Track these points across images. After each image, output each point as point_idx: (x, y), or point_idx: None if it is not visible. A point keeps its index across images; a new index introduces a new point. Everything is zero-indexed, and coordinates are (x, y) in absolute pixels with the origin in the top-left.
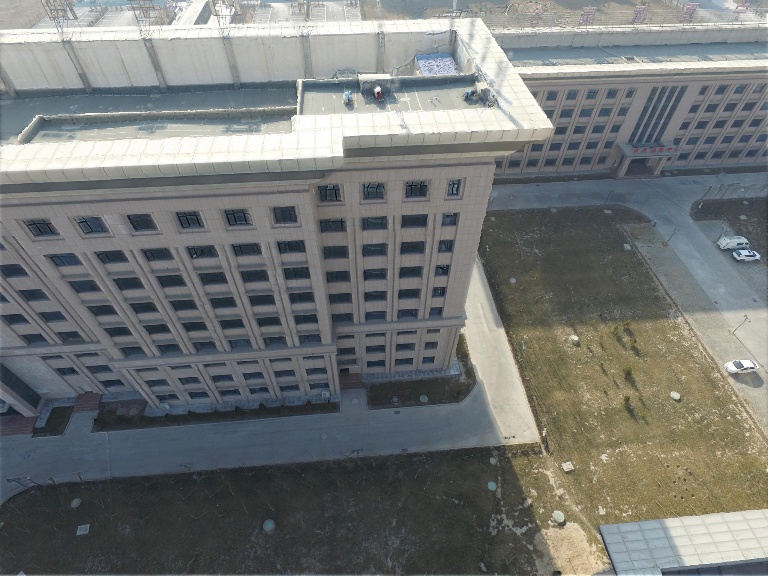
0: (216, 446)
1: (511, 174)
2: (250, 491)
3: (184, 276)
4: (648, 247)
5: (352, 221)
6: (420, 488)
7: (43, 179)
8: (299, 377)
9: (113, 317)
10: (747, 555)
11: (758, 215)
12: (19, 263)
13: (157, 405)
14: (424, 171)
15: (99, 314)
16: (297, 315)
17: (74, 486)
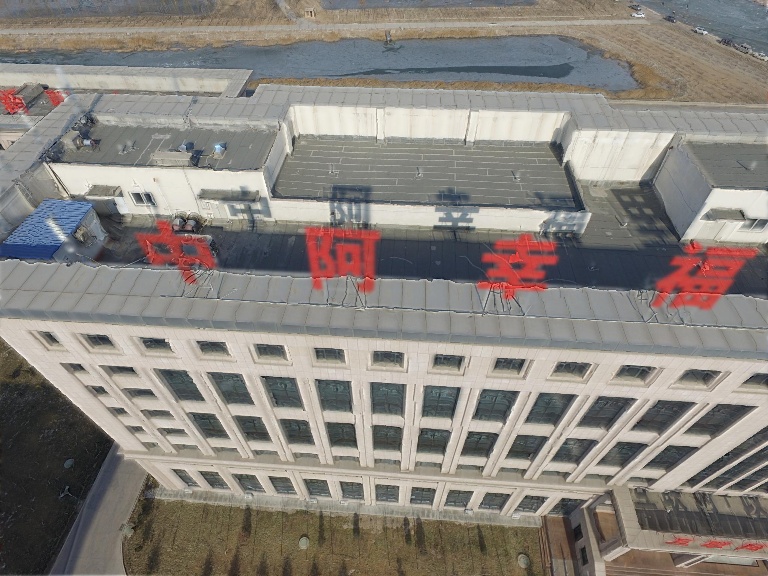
0: None
1: None
2: None
3: None
4: None
5: None
6: None
7: None
8: None
9: None
10: None
11: None
12: None
13: None
14: None
15: None
16: None
17: None
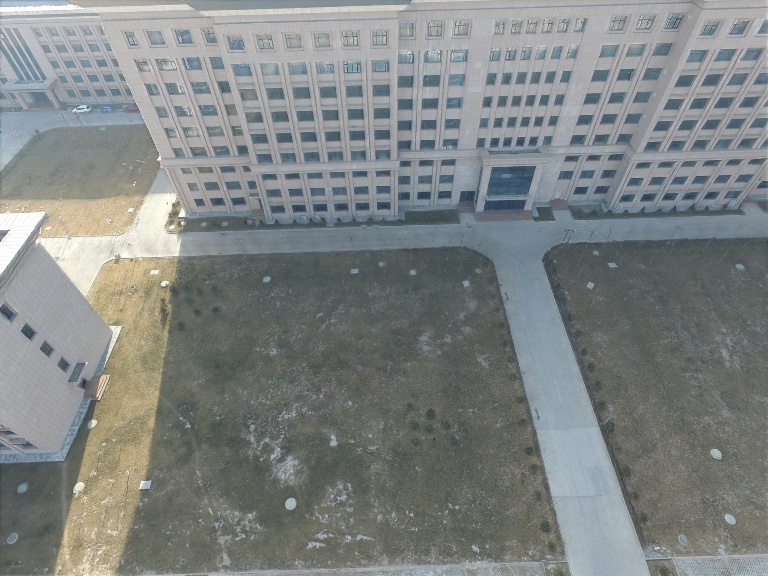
0: (669, 229)
1: None
2: (713, 250)
3: (751, 74)
4: None
5: None
6: None
7: None
8: (728, 184)
9: (671, 111)
10: None
11: None
12: (638, 67)
13: (614, 205)
14: None
15: (664, 109)
16: None
17: (588, 245)
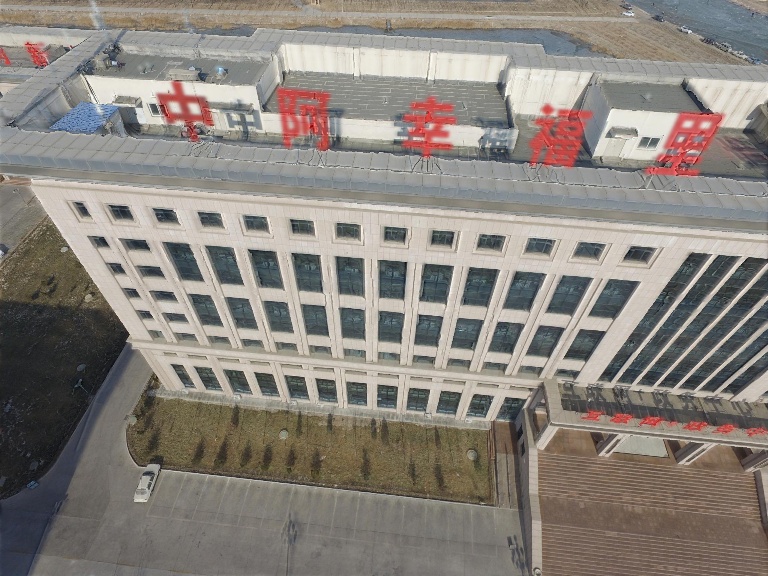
0: None
1: None
2: None
3: None
4: None
5: None
6: None
7: None
8: None
9: None
10: None
11: None
12: None
13: None
14: None
15: None
16: None
17: None
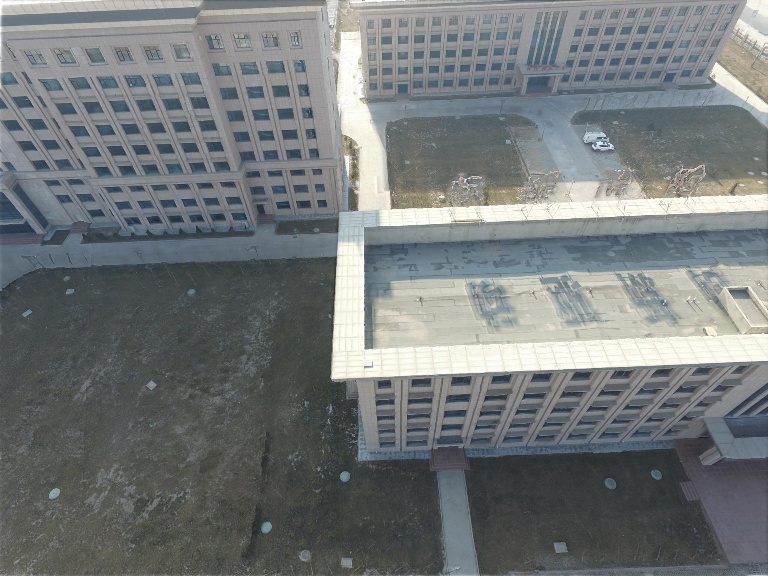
0: (164, 252)
1: (431, 93)
2: (182, 275)
3: (126, 101)
4: (525, 142)
5: (233, 65)
6: (299, 277)
7: (31, 11)
8: (223, 206)
9: (86, 138)
10: (418, 223)
11: (629, 121)
12: (26, 95)
13: (126, 228)
14: (270, 24)
15: (77, 135)
16: (208, 142)
17: (66, 270)
